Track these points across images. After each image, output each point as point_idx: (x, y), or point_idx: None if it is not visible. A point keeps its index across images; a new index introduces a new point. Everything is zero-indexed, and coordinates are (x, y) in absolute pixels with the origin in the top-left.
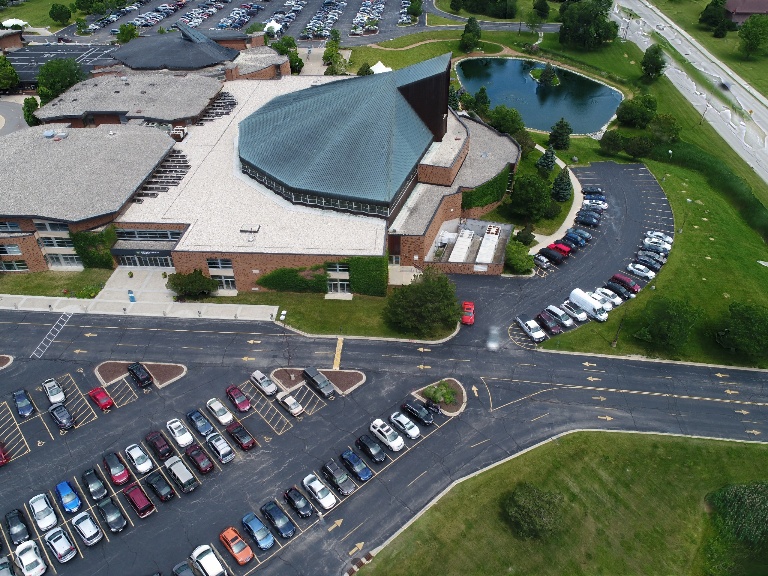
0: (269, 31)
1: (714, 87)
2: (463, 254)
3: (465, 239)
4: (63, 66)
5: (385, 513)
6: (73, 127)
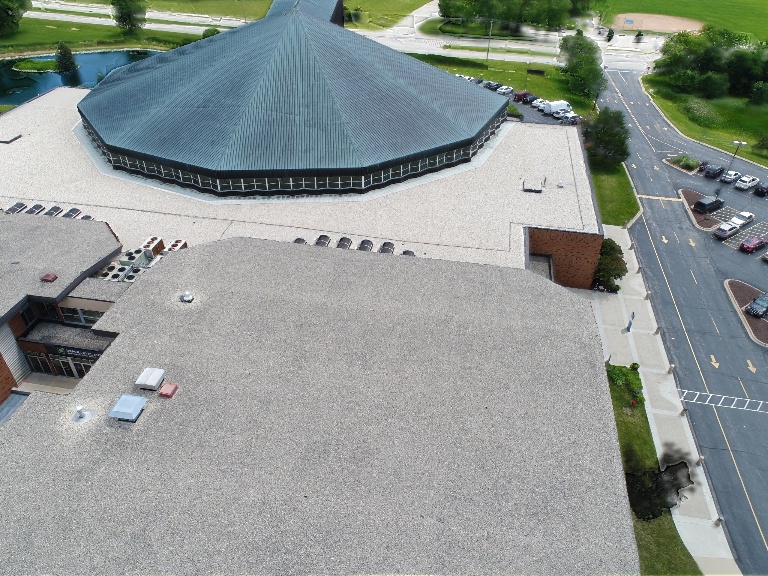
0: None
1: (243, 4)
2: None
3: None
4: None
5: None
6: None
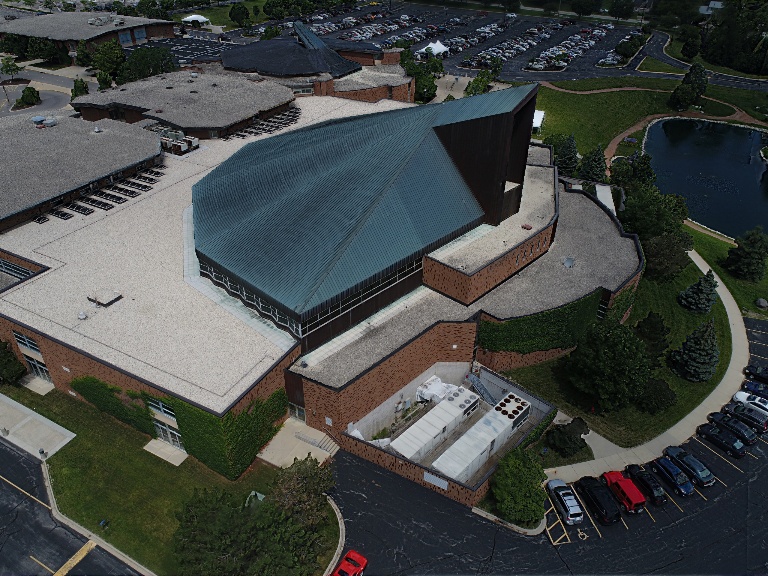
0: (427, 52)
1: None
2: (425, 438)
3: (452, 407)
4: (150, 54)
5: None
6: (101, 118)
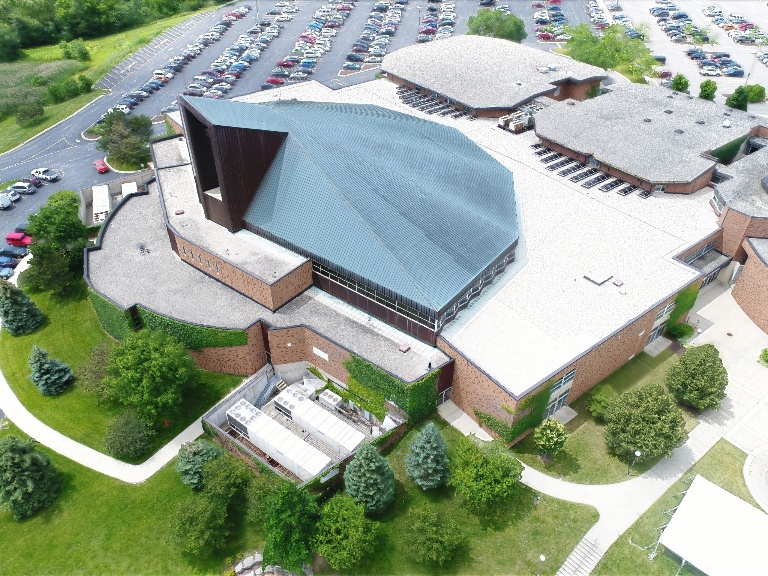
0: None
1: None
2: (125, 191)
3: None
4: None
5: (104, 101)
6: None
